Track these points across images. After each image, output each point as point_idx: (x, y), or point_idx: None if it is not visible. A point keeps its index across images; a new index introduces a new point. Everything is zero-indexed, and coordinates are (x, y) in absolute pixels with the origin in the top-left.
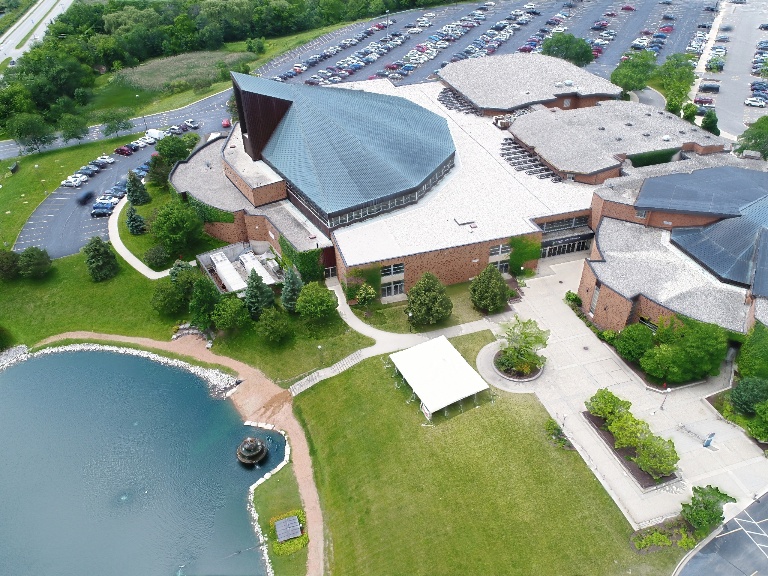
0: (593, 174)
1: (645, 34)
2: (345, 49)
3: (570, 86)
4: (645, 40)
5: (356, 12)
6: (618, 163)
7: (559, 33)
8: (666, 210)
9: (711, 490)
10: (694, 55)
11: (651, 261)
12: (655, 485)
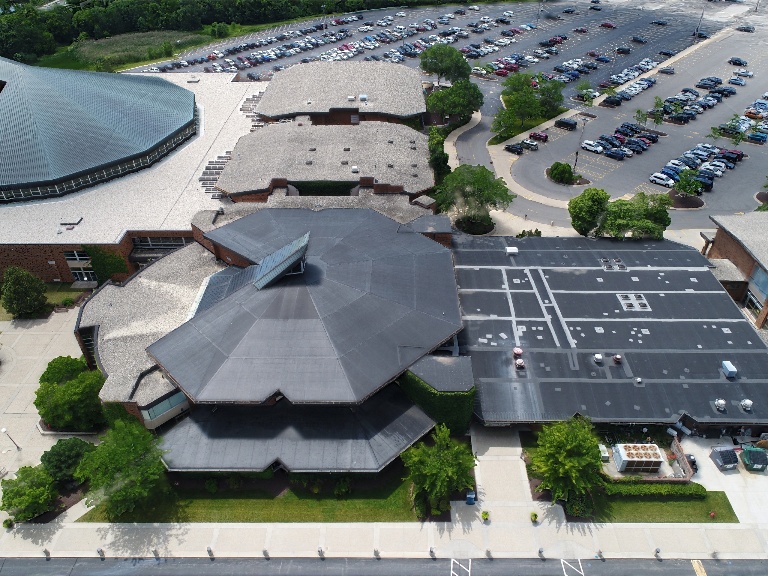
0: (237, 195)
1: (590, 55)
2: (281, 41)
3: (363, 101)
4: (577, 62)
5: (333, 5)
6: (265, 188)
7: (438, 44)
8: (219, 244)
9: None
10: (612, 85)
11: (163, 295)
12: None
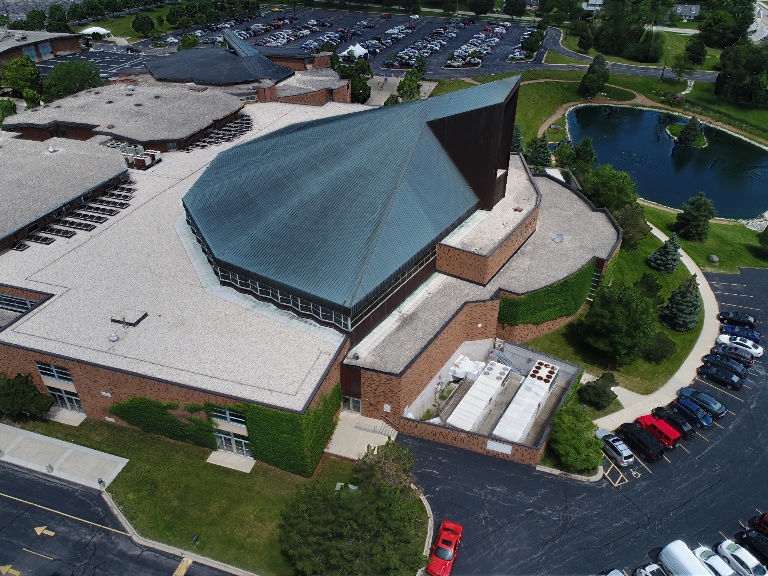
0: None
1: None
2: None
3: None
4: None
5: None
6: None
7: None
8: None
9: None
10: None
11: None
12: (418, 84)
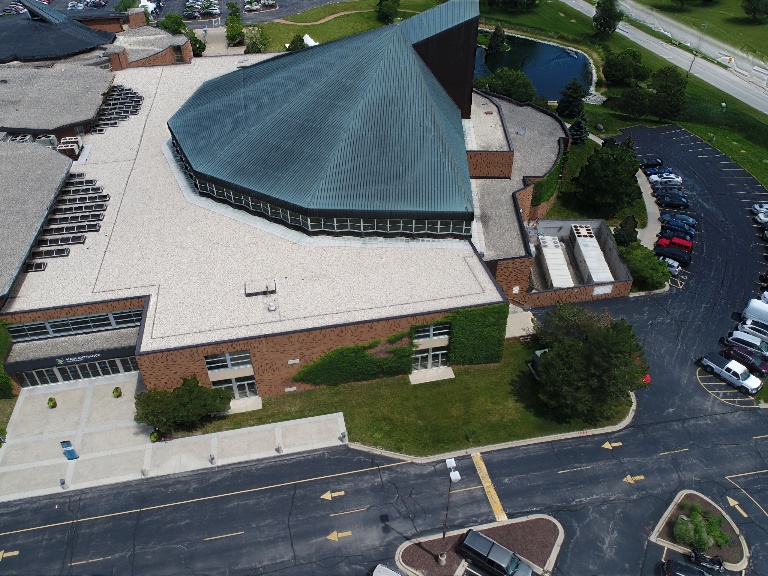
0: None
1: None
2: None
3: None
4: None
5: None
6: None
7: None
8: None
9: (231, 6)
10: None
11: (140, 45)
12: None
